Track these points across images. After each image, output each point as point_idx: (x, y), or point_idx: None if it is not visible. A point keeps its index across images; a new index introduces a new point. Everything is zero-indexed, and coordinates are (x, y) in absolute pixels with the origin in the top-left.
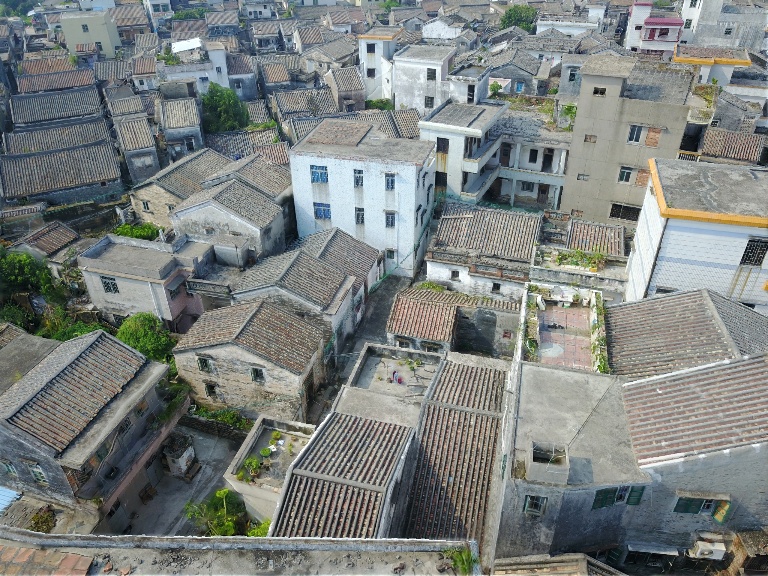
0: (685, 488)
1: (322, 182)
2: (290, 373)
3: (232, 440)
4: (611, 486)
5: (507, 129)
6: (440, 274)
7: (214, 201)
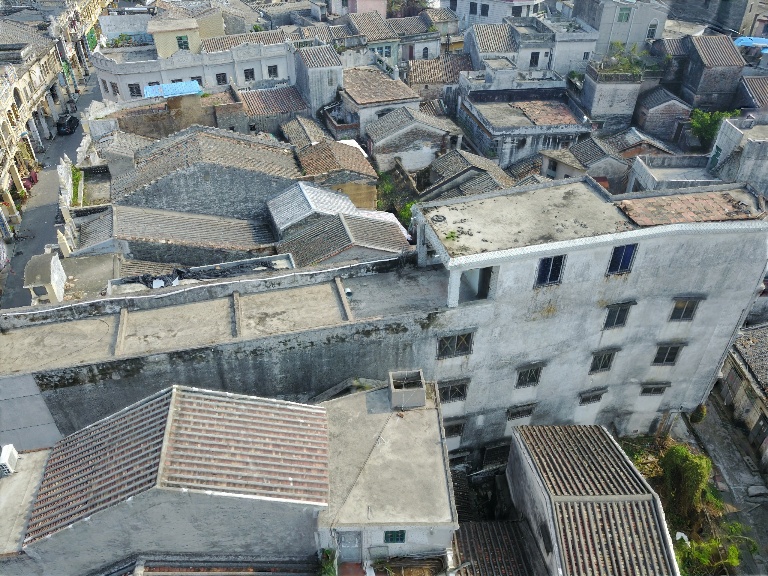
0: None
1: None
2: None
3: None
4: None
5: None
6: None
7: None
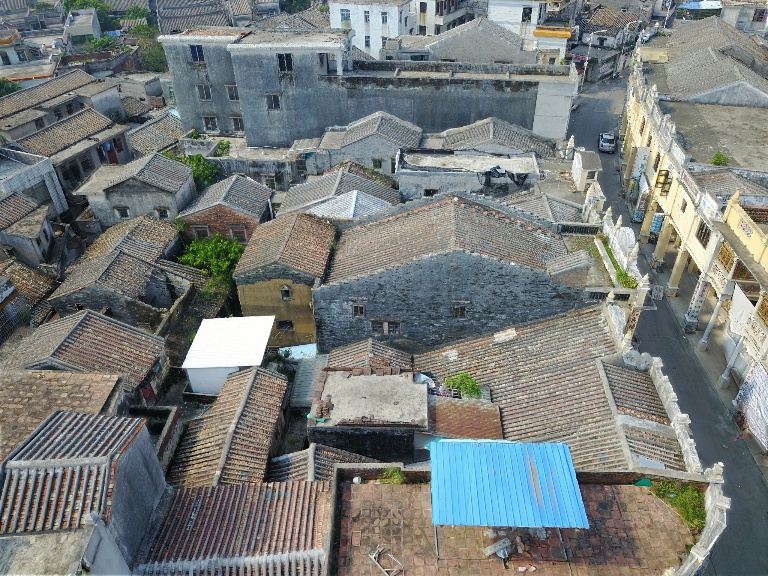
0: (442, 56)
1: (347, 20)
2: None
3: None
4: (414, 51)
5: (472, 6)
6: None
7: (286, 25)
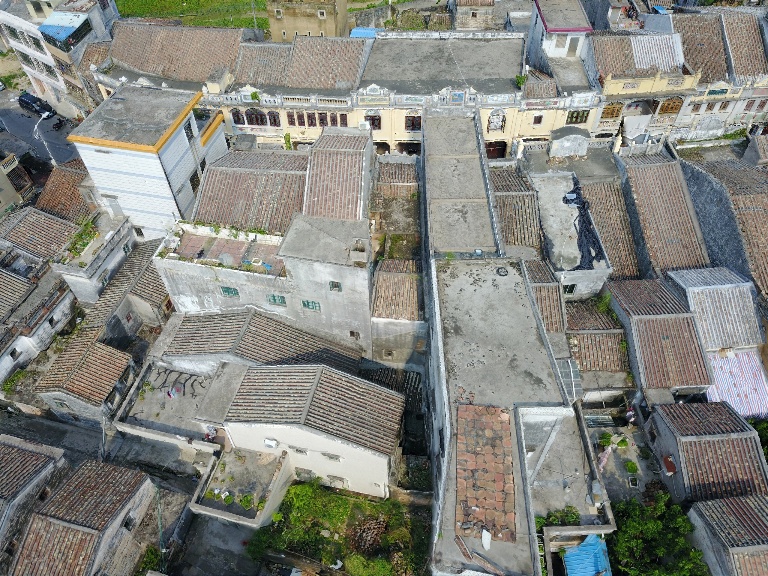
0: None
1: None
2: (144, 484)
3: (169, 575)
4: None
5: None
6: (4, 368)
7: None
